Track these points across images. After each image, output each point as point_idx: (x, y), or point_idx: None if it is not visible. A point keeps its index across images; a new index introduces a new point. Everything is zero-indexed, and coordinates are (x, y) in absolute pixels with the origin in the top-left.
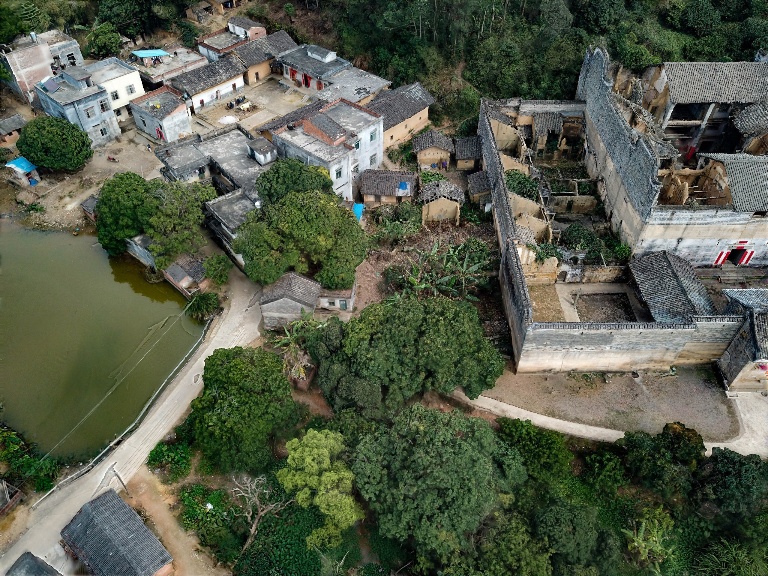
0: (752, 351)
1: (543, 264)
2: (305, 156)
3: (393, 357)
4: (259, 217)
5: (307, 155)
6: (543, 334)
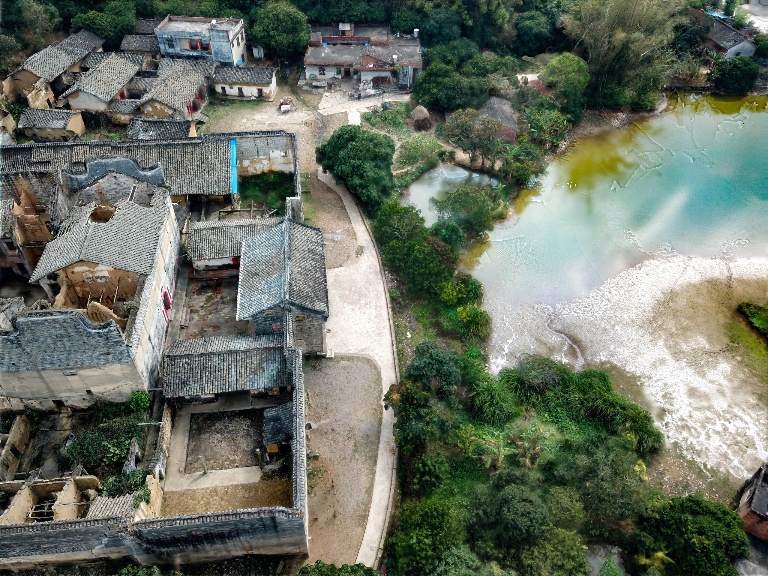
0: (319, 318)
1: (150, 495)
2: None
3: None
4: None
5: None
6: None
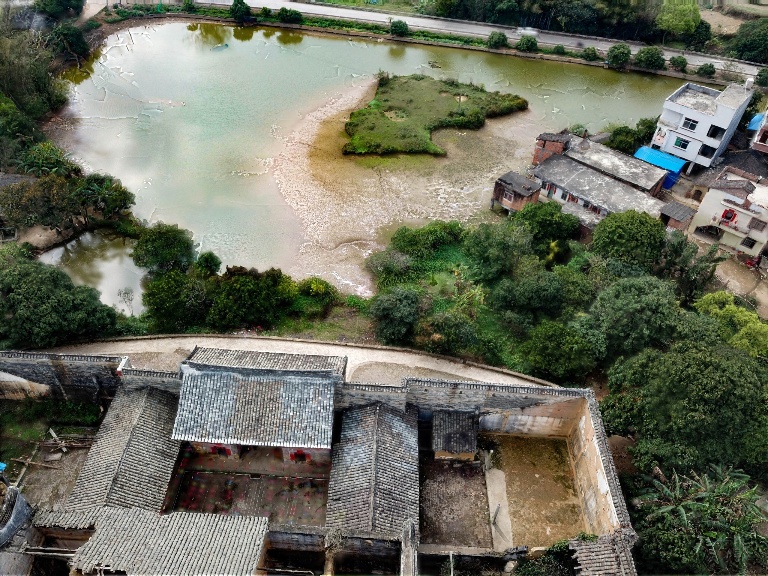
0: None
1: None
2: None
3: None
4: None
5: None
6: None
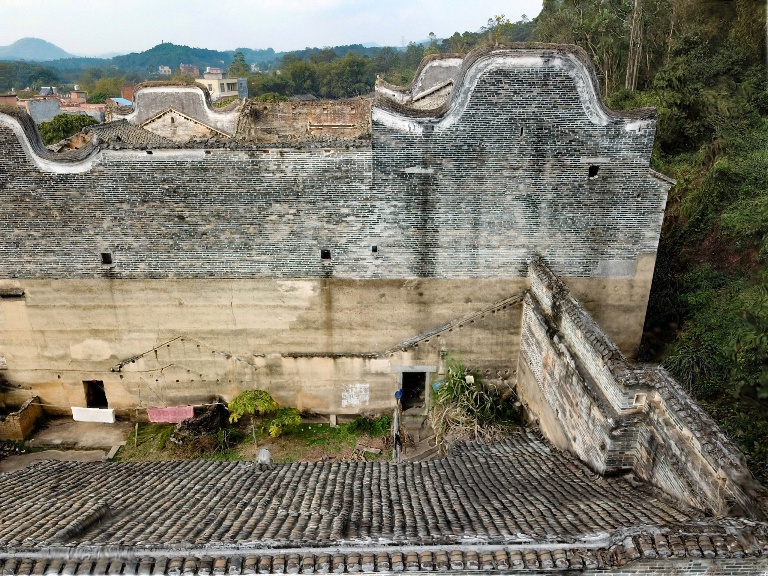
0: None
1: None
2: None
3: None
4: None
5: None
6: None
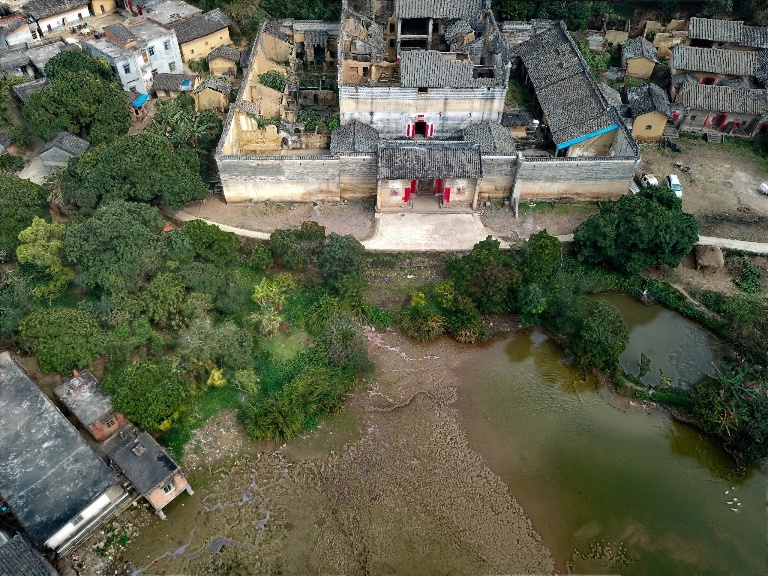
0: None
1: (266, 131)
2: (101, 55)
3: (107, 173)
4: (44, 92)
5: (102, 54)
6: (230, 165)
